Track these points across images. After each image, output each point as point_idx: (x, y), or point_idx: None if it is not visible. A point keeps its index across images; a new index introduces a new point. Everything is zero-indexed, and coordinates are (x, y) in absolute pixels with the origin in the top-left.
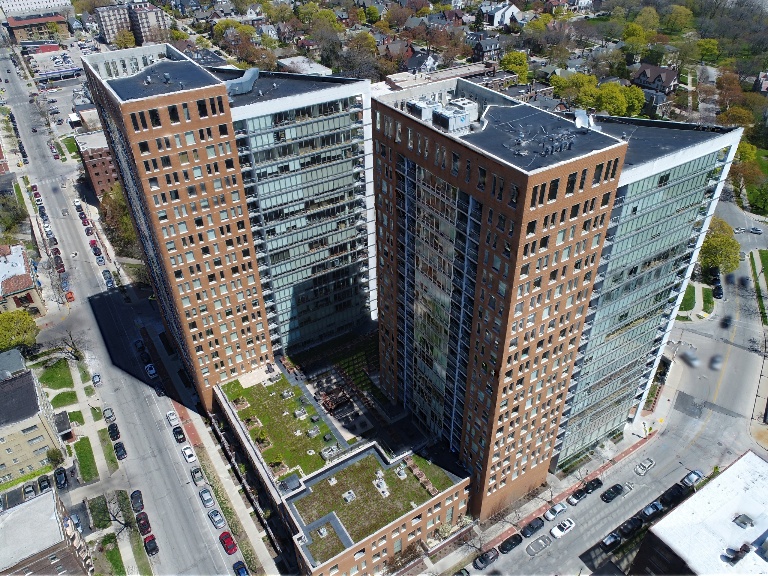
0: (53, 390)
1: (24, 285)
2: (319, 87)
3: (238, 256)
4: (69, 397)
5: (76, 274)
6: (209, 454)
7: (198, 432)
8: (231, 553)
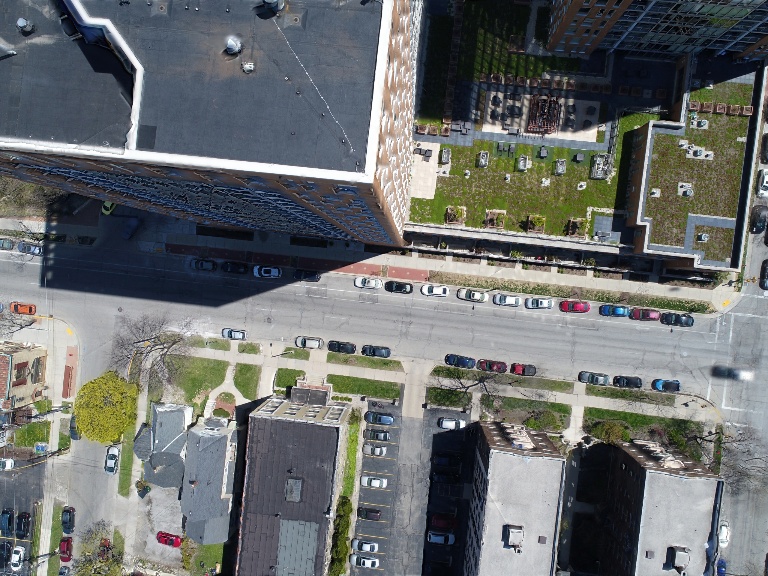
0: (222, 386)
1: (1, 368)
2: None
3: (407, 110)
4: (247, 373)
5: None
6: (451, 272)
7: (411, 268)
8: (589, 310)
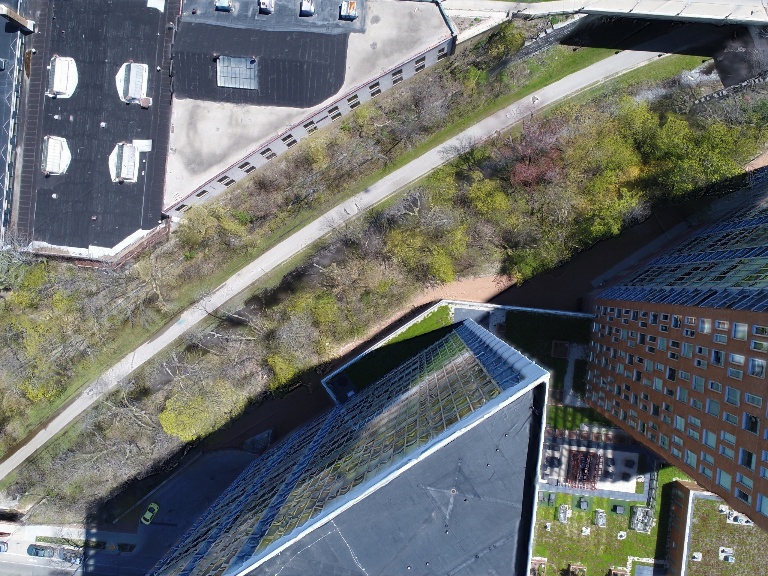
0: None
1: None
2: (454, 489)
3: None
4: None
5: None
6: None
7: None
8: None
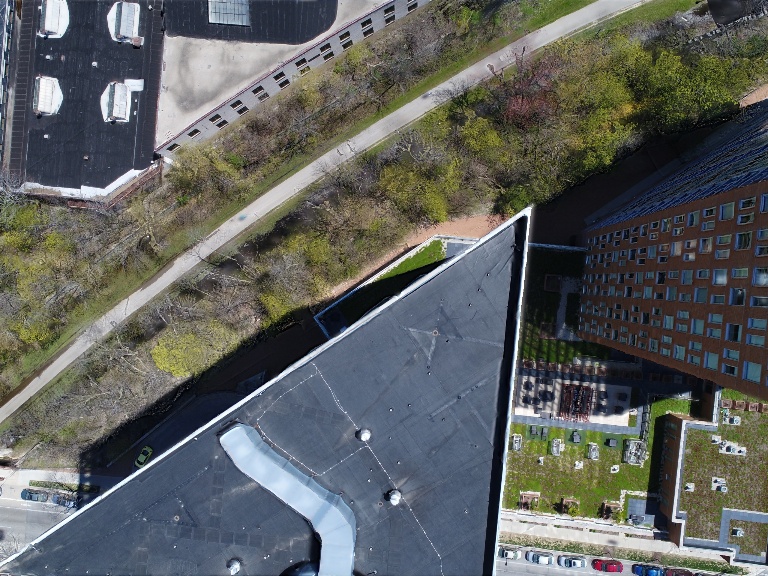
0: None
1: None
2: (436, 330)
3: None
4: None
5: (1, 533)
6: None
7: None
8: (622, 570)
